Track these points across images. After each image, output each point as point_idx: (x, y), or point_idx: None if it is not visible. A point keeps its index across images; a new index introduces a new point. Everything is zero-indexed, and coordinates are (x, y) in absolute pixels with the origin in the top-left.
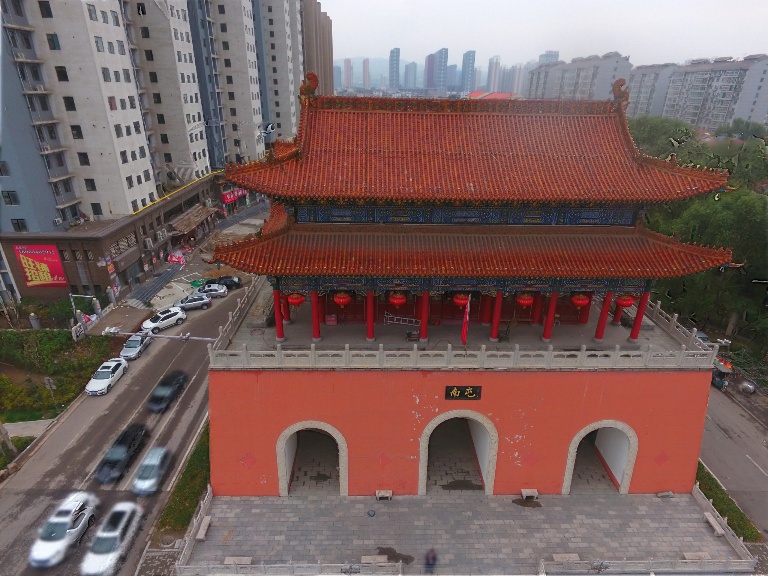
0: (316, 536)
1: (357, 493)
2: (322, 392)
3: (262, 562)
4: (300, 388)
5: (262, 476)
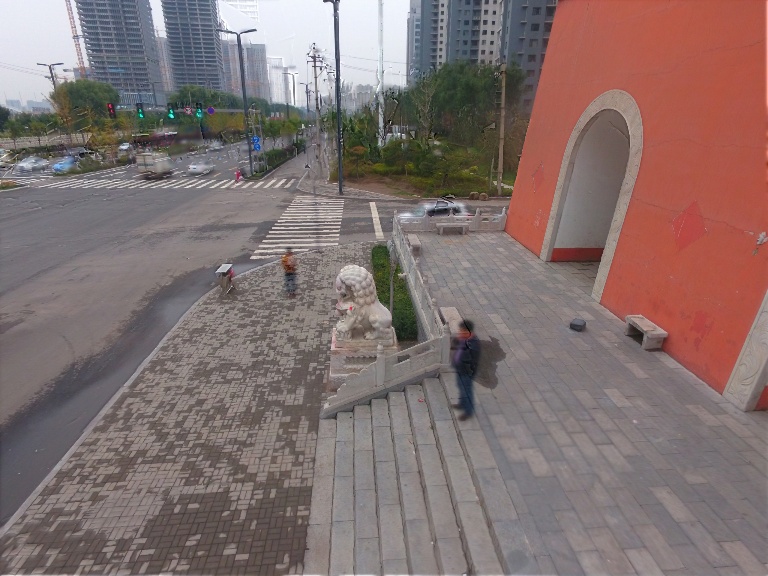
0: (484, 284)
1: (613, 305)
2: (653, 5)
3: (406, 235)
4: (628, 5)
5: (539, 211)
